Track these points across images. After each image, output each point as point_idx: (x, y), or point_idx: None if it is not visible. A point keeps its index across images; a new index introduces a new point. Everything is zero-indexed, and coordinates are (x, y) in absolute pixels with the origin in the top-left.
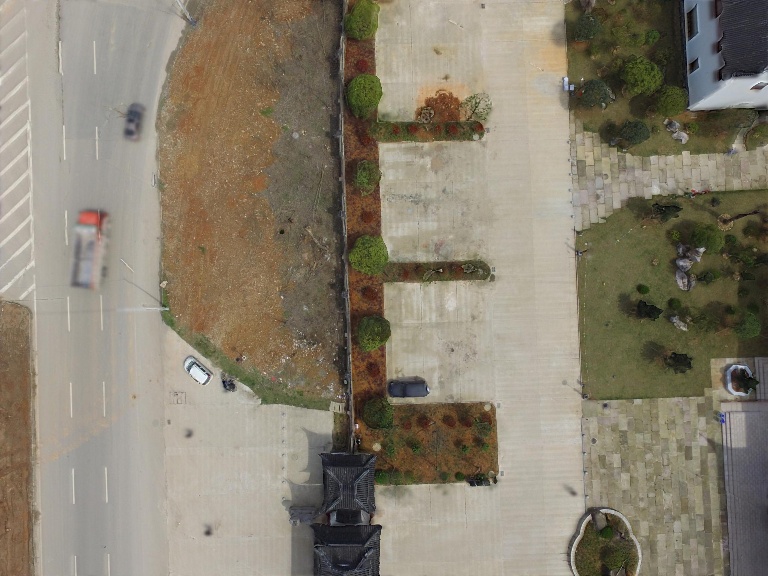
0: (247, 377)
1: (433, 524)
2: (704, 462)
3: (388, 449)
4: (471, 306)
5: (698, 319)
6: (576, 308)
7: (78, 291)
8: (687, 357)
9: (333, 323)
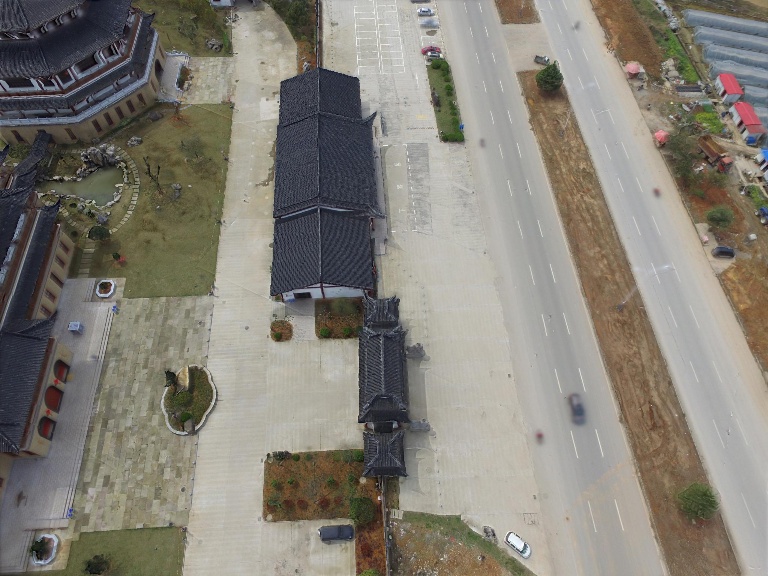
0: (475, 540)
1: (319, 420)
2: (95, 474)
3: (354, 479)
4: None
5: None
6: None
7: None
8: (90, 571)
9: None
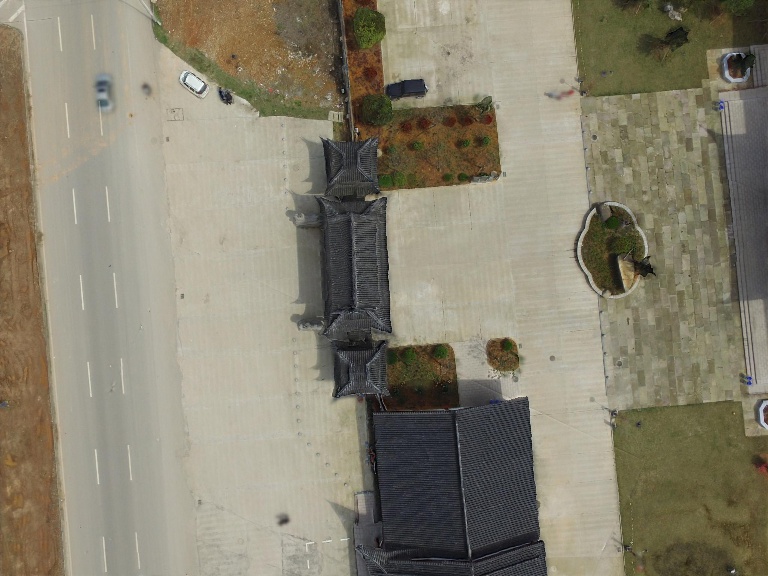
0: (244, 89)
1: (438, 227)
2: (705, 153)
3: (389, 149)
4: (465, 9)
5: (692, 0)
6: (570, 6)
7: (68, 11)
8: (683, 30)
9: (327, 33)
